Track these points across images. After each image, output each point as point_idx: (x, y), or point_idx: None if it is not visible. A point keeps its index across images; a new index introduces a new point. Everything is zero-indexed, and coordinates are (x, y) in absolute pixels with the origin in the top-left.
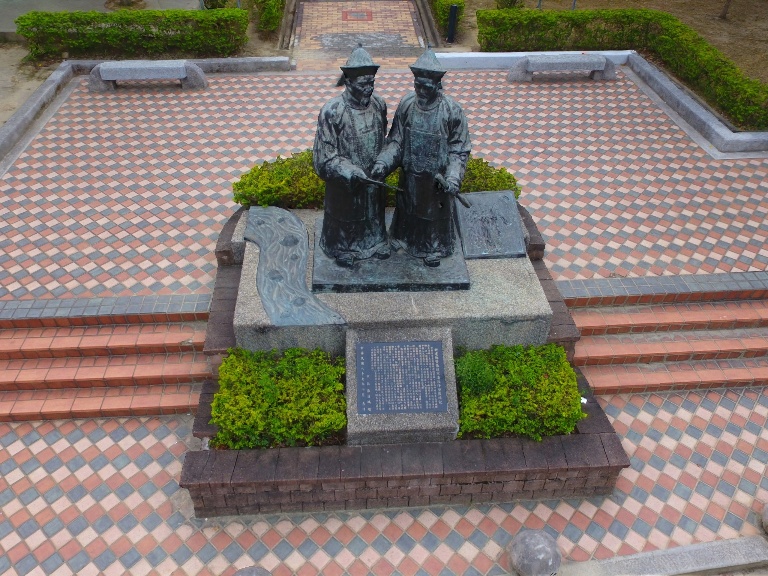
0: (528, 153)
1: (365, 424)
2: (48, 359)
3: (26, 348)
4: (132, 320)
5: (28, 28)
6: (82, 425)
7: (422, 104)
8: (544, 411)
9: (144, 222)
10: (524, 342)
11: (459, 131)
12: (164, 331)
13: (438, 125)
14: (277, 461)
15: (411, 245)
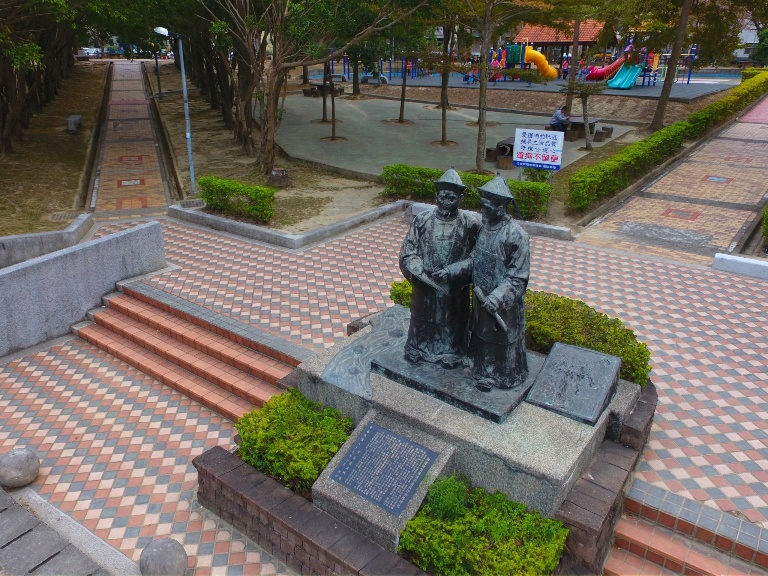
0: (755, 367)
1: (328, 488)
2: (218, 360)
3: (210, 346)
4: (275, 355)
5: (389, 173)
6: (203, 411)
7: (484, 223)
8: (482, 568)
9: (345, 303)
10: (530, 504)
11: (515, 256)
12: (287, 371)
13: (495, 245)
14: (258, 483)
15: (475, 365)
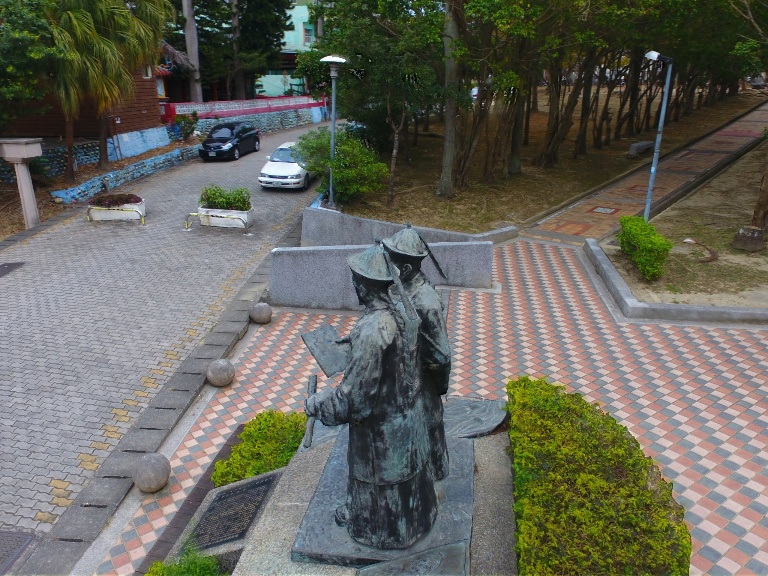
0: None
1: None
2: None
3: None
4: None
5: None
6: None
7: None
8: None
9: None
10: None
11: None
12: None
13: None
14: None
15: None
